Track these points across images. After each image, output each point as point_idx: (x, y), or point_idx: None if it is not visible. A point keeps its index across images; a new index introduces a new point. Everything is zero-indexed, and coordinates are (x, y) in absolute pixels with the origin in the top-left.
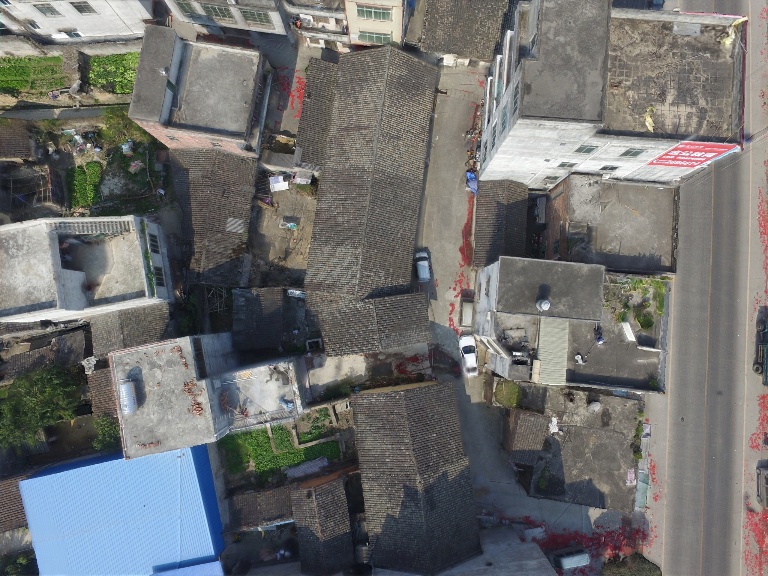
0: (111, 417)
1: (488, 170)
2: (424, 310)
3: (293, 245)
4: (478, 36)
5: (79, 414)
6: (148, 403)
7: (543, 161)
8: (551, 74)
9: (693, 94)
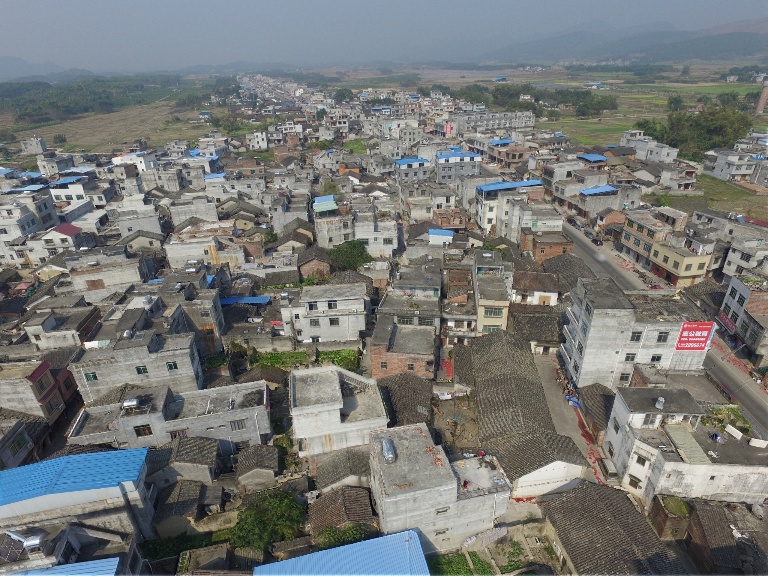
0: (334, 527)
1: (583, 371)
2: (576, 447)
3: (458, 434)
4: (546, 331)
5: (298, 537)
6: (400, 460)
7: (615, 354)
8: (601, 298)
9: (676, 312)
